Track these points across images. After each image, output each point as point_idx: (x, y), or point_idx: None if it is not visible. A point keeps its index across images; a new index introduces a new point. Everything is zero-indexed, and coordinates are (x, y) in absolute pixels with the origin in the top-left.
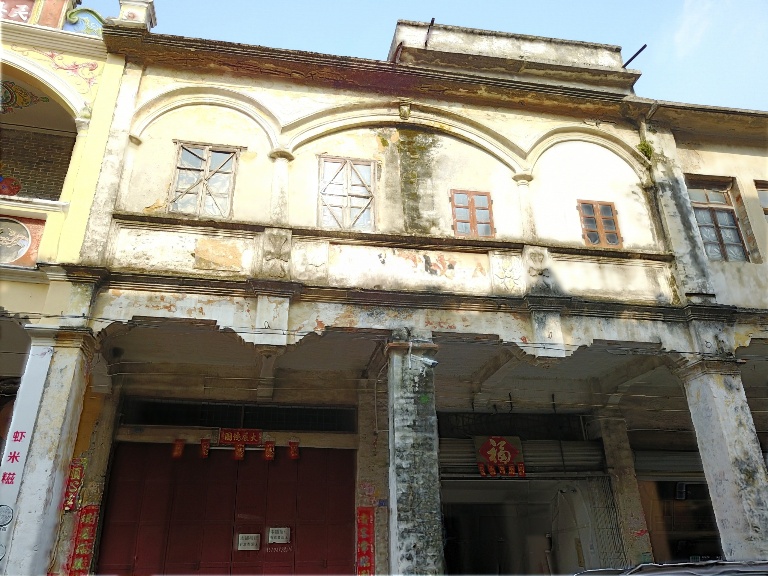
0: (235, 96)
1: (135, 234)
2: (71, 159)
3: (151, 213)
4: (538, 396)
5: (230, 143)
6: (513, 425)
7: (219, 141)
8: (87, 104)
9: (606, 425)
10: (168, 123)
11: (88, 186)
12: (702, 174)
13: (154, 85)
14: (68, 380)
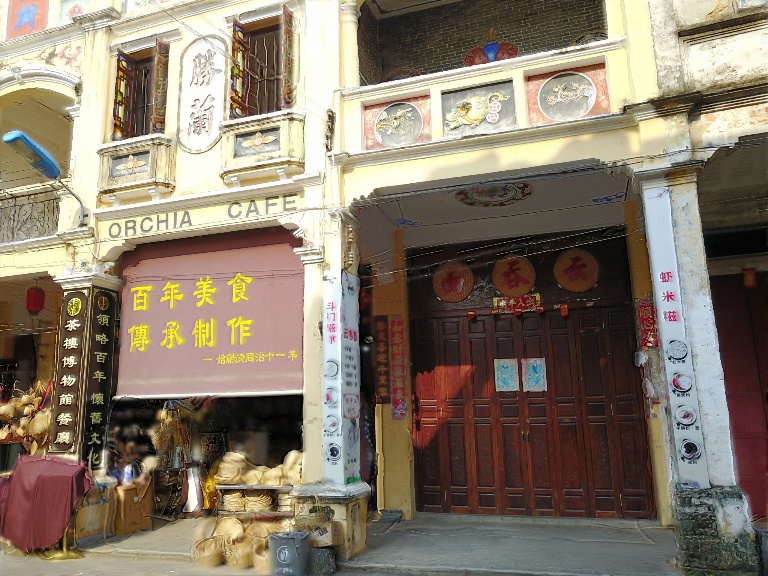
0: None
1: (709, 47)
2: None
3: (717, 18)
4: None
5: None
6: None
7: None
8: None
9: None
10: None
11: (641, 11)
12: None
13: None
14: (695, 216)
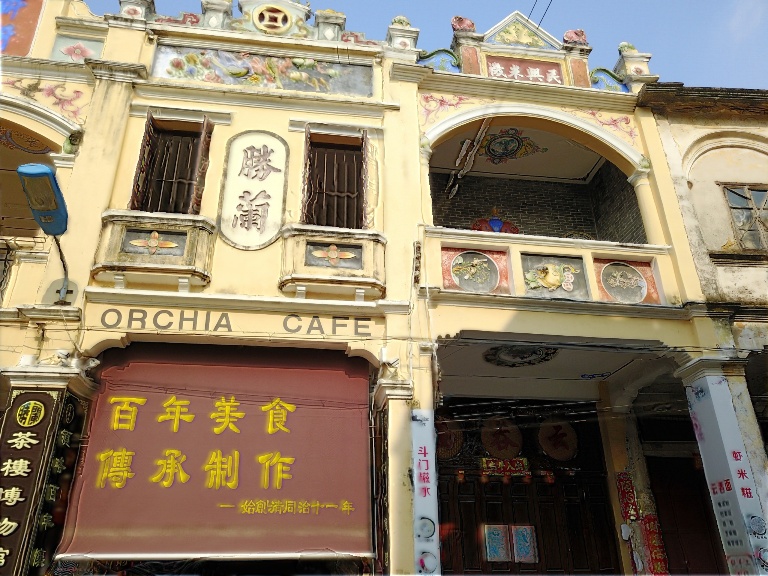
0: (753, 138)
1: (730, 271)
2: (646, 206)
3: (730, 251)
4: None
5: (762, 181)
6: None
7: (753, 180)
8: (644, 155)
9: None
10: (704, 167)
11: (680, 230)
12: None
13: (680, 133)
14: (749, 405)
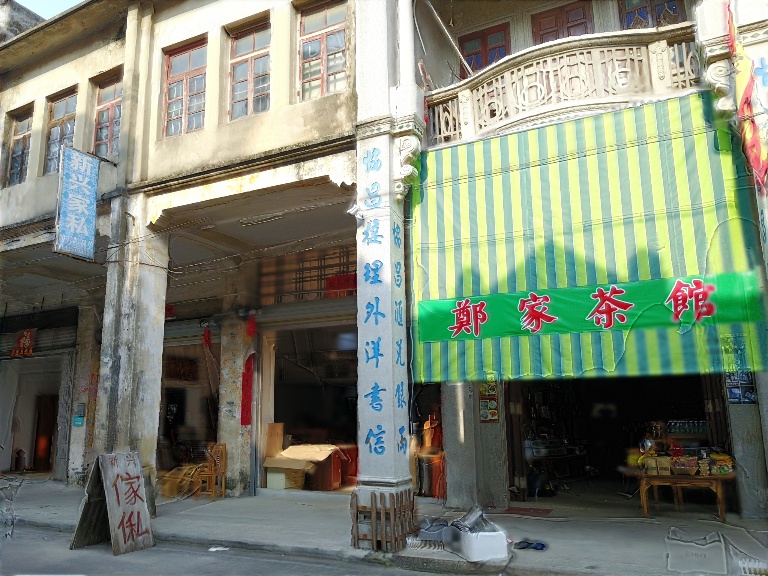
0: None
1: None
2: None
3: None
4: (54, 297)
5: None
6: (56, 318)
7: None
8: None
9: (81, 313)
10: None
11: None
12: (17, 108)
13: None
14: None
